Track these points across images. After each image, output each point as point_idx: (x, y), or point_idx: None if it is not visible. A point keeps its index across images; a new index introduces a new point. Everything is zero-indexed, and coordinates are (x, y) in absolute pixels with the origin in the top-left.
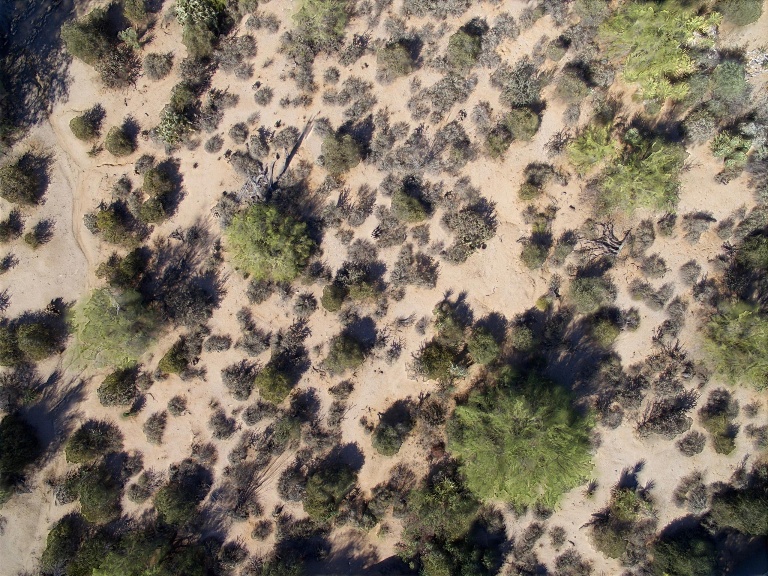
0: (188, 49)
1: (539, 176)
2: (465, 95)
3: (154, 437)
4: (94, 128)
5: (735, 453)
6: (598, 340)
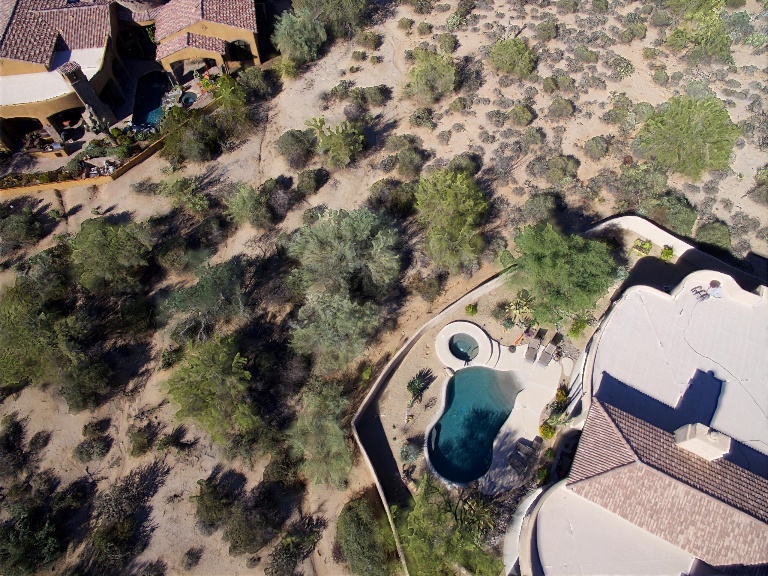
0: None
1: None
2: (604, 21)
3: (446, 139)
4: None
5: None
6: None
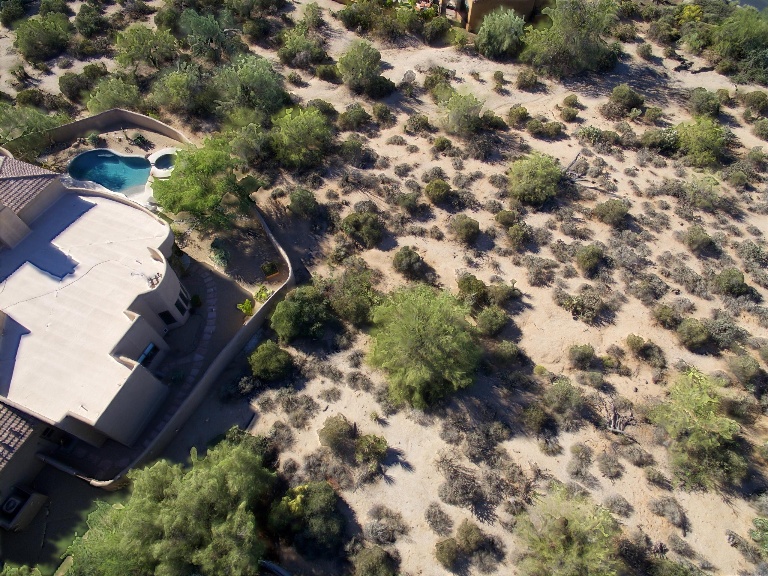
0: (643, 134)
1: (653, 353)
2: (694, 290)
3: (393, 140)
4: (573, 106)
5: (436, 575)
6: (525, 409)
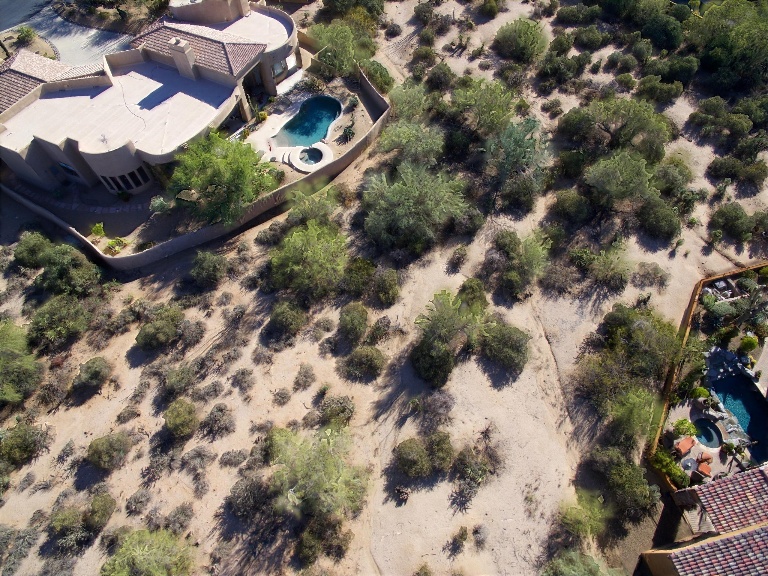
0: None
1: None
2: None
3: None
4: None
5: None
6: None
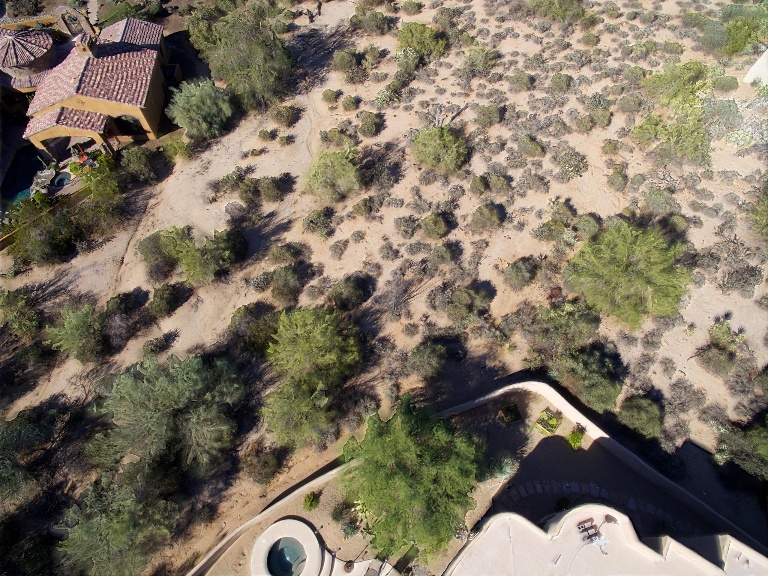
0: (401, 67)
1: (614, 144)
2: (562, 103)
3: (338, 252)
4: (335, 98)
5: None
6: (674, 226)
